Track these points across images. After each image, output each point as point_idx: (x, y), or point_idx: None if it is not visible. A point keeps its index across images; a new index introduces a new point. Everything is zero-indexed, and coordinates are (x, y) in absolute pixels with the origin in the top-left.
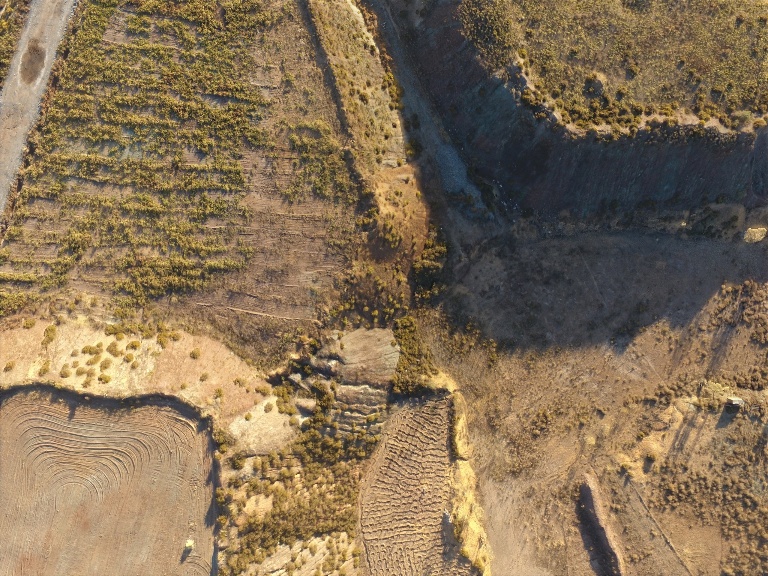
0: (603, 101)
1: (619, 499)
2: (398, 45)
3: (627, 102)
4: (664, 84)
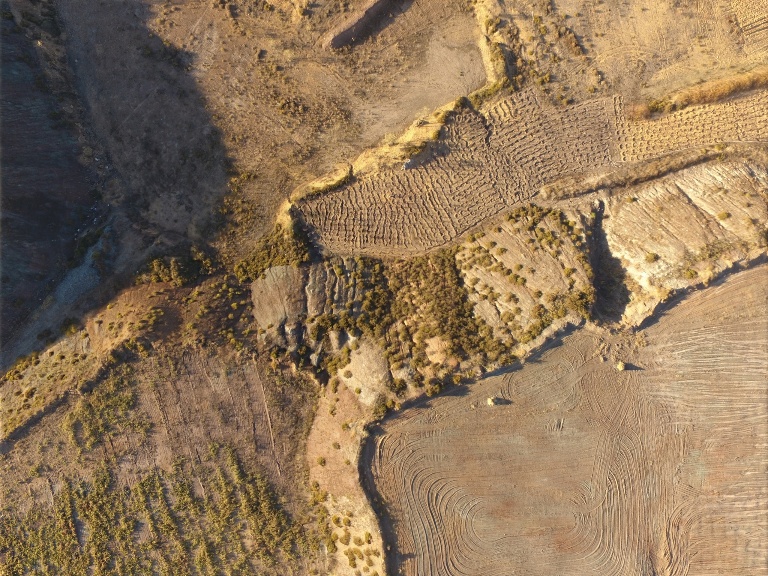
0: None
1: (334, 7)
2: None
3: None
4: None
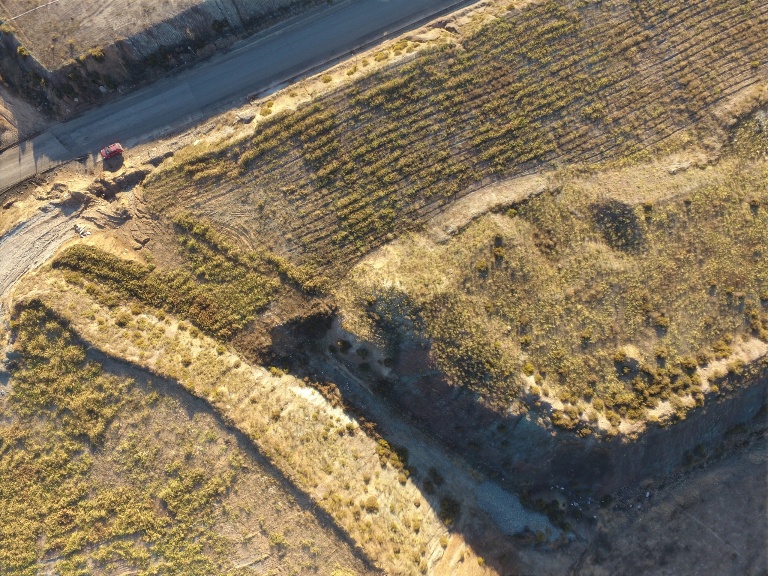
0: (646, 376)
1: None
2: (374, 401)
3: (673, 364)
4: (705, 321)
